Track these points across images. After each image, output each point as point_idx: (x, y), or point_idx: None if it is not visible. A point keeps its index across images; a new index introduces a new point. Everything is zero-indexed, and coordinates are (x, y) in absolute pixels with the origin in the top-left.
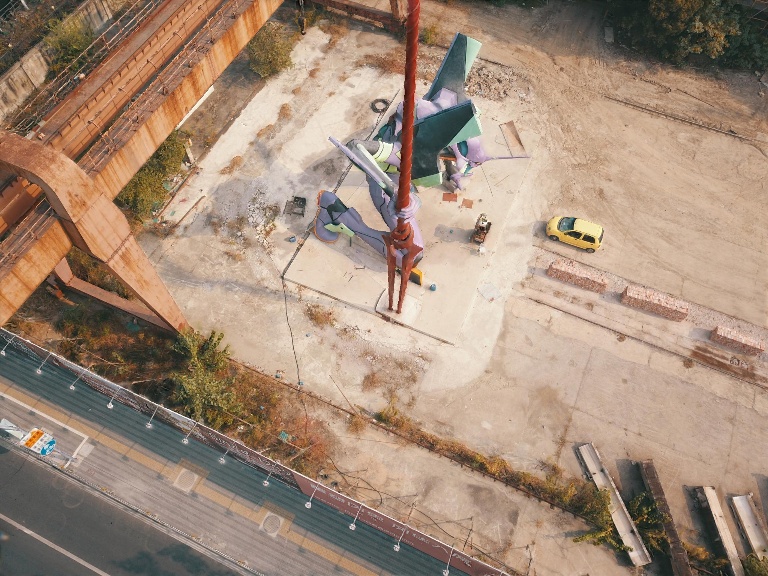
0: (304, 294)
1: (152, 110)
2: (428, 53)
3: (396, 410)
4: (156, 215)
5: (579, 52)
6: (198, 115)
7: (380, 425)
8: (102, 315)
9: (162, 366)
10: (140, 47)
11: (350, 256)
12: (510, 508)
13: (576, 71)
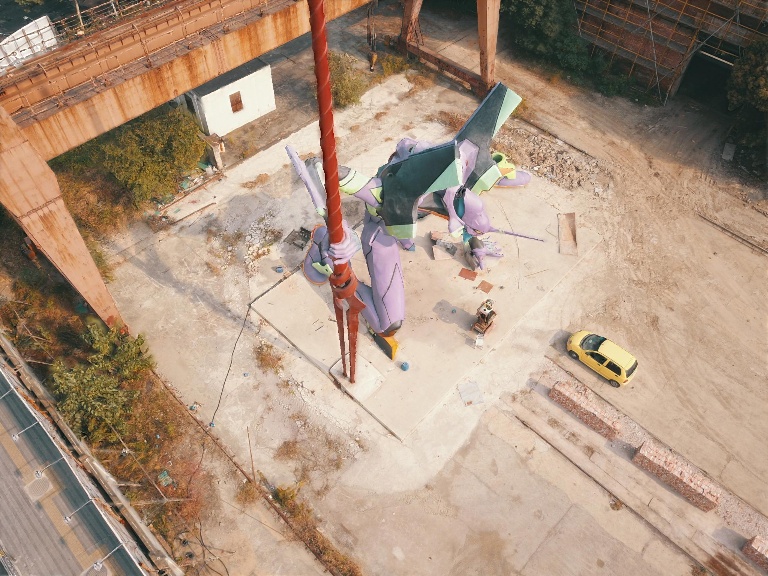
0: (264, 330)
1: (127, 78)
2: (509, 124)
3: (301, 494)
4: (161, 208)
5: (684, 161)
6: (249, 128)
7: (274, 505)
8: (57, 287)
9: (86, 357)
10: (154, 22)
11: (330, 304)
12: None
13: (673, 180)
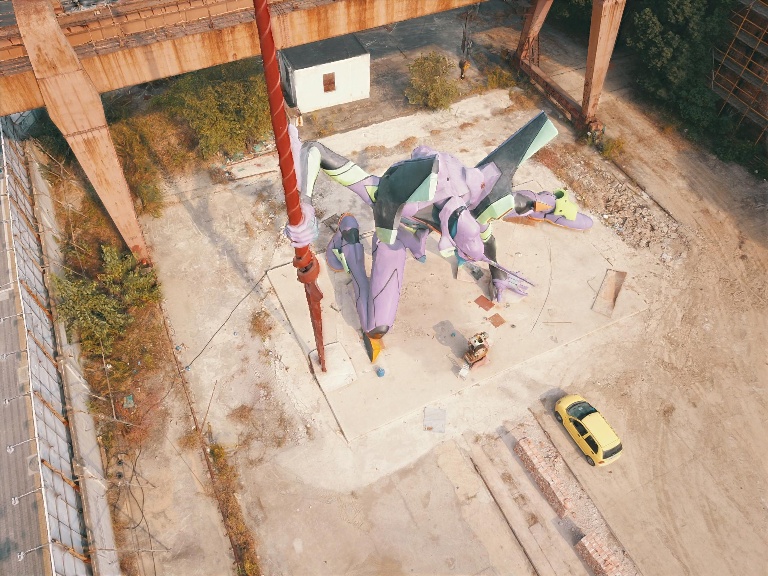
0: (269, 298)
1: (188, 33)
2: (596, 164)
3: (236, 457)
4: (228, 164)
5: None
6: (337, 109)
7: (208, 458)
8: None
9: None
10: None
11: (337, 292)
12: None
13: (762, 268)
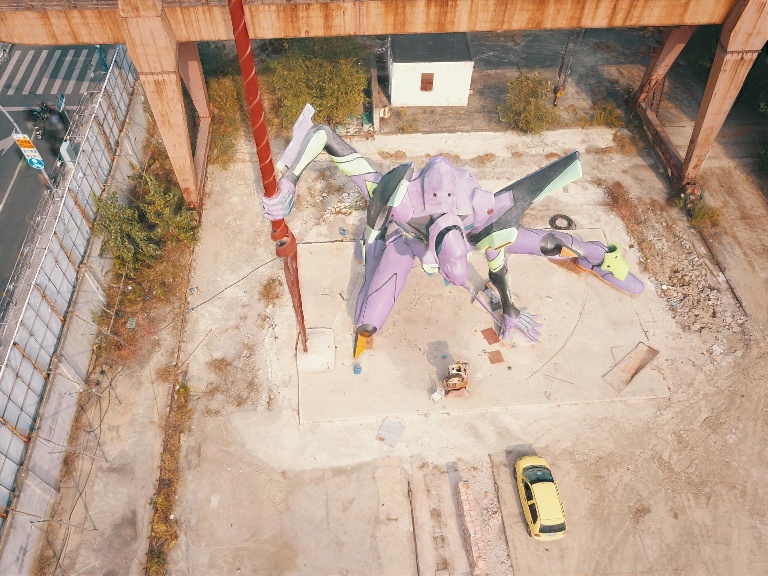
0: None
1: (265, 2)
2: (679, 230)
3: (197, 402)
4: None
5: None
6: (430, 110)
7: (174, 394)
8: (192, 153)
9: None
10: None
11: (352, 282)
12: (120, 569)
13: None
